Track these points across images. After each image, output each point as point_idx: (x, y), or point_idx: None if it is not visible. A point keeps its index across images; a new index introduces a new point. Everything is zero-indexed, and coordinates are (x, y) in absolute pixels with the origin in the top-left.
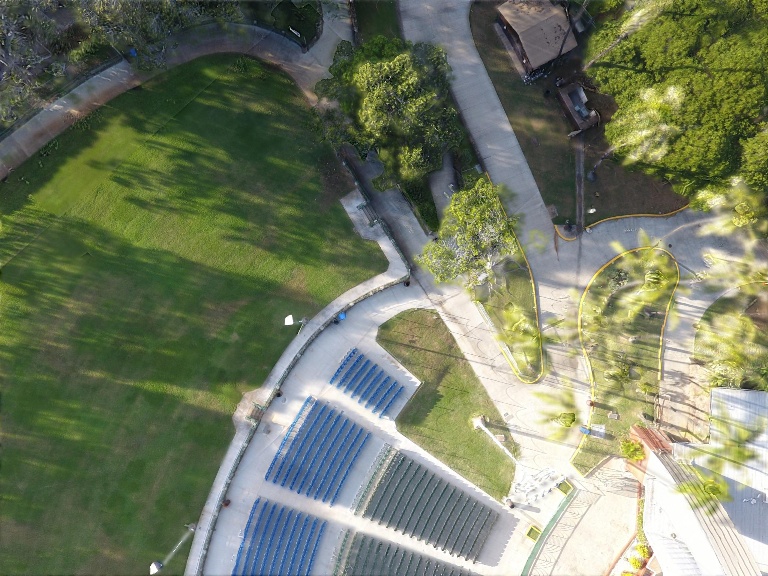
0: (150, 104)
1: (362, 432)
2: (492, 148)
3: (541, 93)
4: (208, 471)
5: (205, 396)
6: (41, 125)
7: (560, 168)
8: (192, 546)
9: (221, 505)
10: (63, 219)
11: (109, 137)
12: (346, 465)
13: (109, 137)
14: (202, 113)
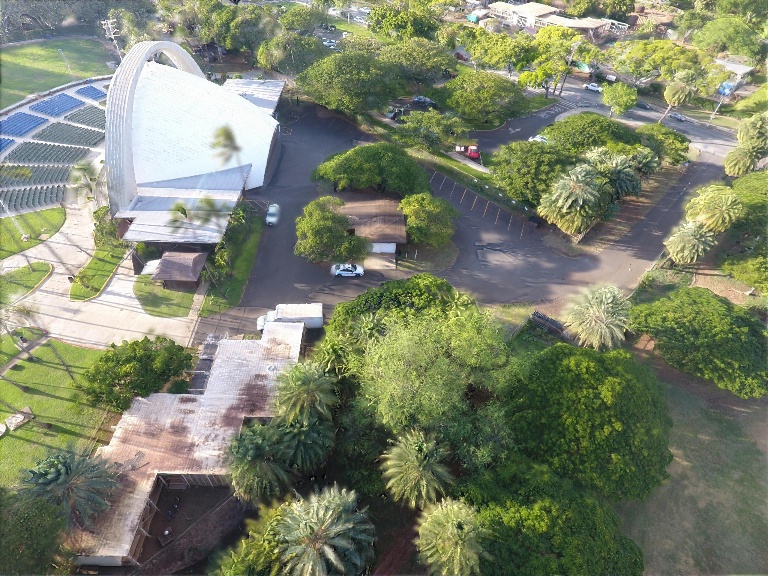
0: None
1: None
2: None
3: None
4: None
5: None
6: (2, 45)
7: (200, 66)
8: None
9: (3, 113)
10: None
11: None
12: None
13: None
14: (64, 46)
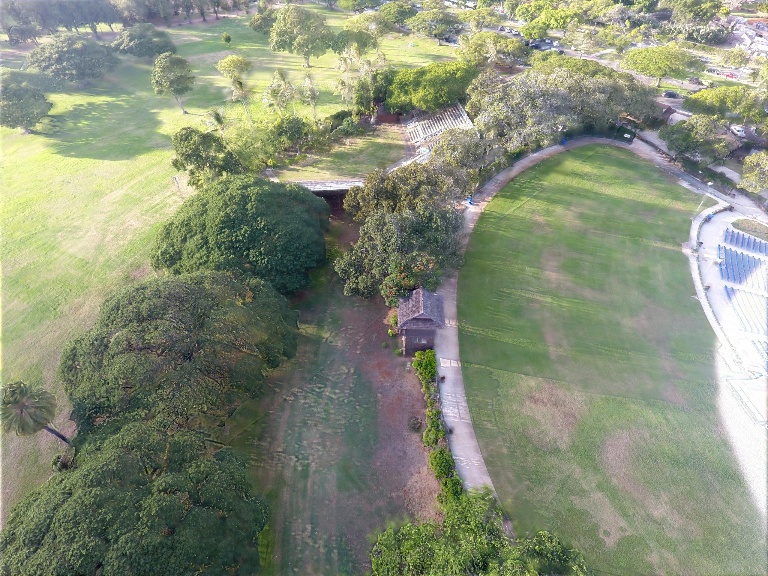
0: (575, 154)
1: (760, 260)
2: (729, 176)
3: (735, 162)
4: (686, 273)
5: (662, 243)
6: None
7: None
8: (702, 306)
9: (705, 288)
10: (555, 183)
11: (563, 162)
12: (764, 273)
13: (563, 162)
14: (599, 157)
